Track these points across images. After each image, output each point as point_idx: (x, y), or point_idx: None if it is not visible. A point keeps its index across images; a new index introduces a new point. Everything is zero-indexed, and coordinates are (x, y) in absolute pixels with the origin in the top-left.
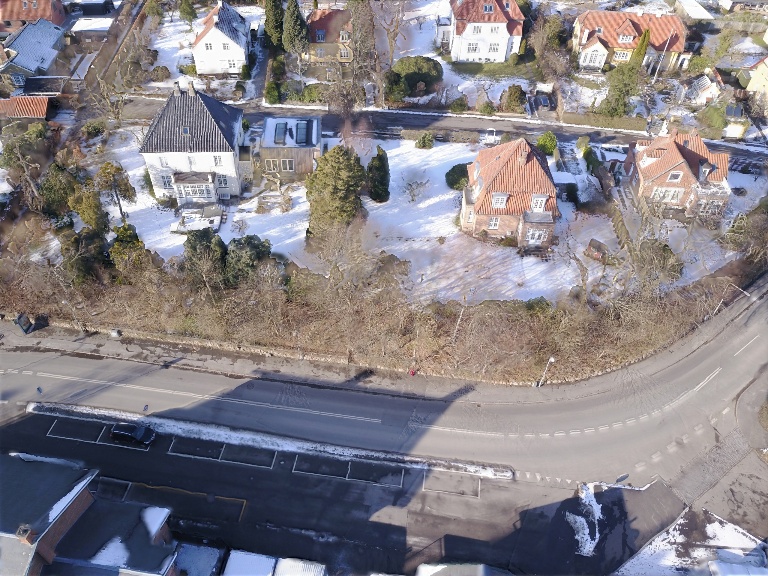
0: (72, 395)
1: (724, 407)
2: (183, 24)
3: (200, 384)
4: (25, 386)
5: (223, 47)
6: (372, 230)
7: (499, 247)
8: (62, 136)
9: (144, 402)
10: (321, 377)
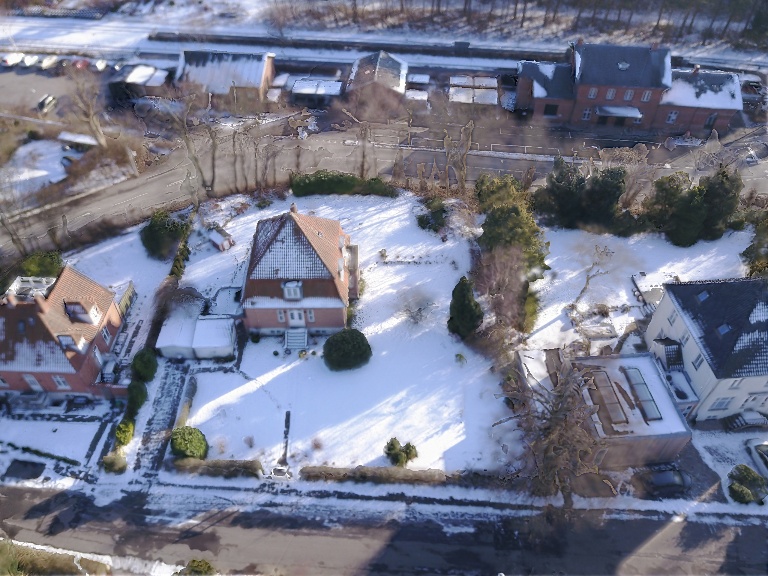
0: (647, 172)
1: (186, 166)
2: None
3: None
4: None
5: None
6: (461, 273)
7: None
8: None
9: None
10: None
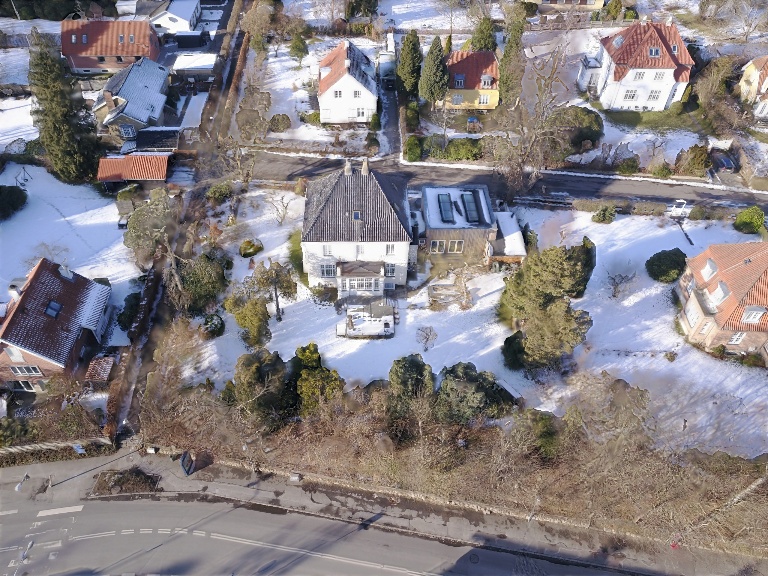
0: (259, 569)
1: None
2: (289, 59)
3: (412, 554)
4: (200, 554)
5: (354, 95)
6: None
7: (743, 367)
8: (184, 201)
9: None
10: (559, 546)
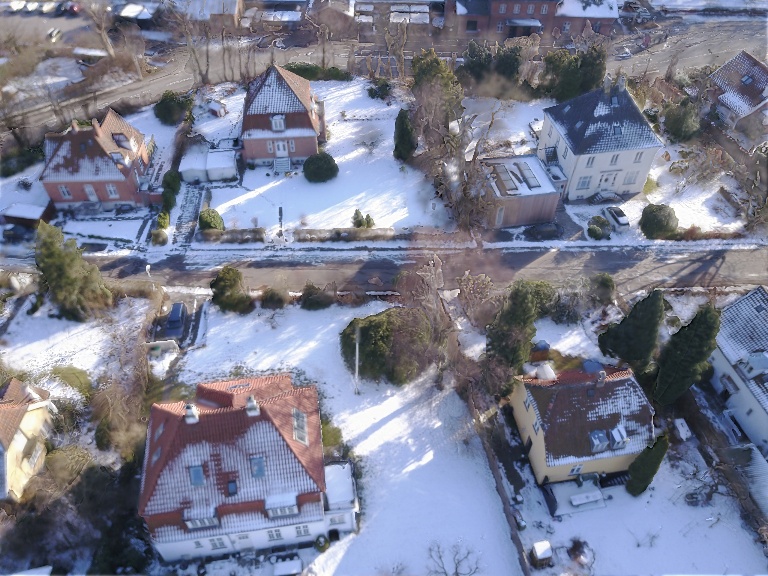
0: None
1: (180, 72)
2: None
3: None
4: None
5: None
6: None
7: None
8: None
9: None
10: None
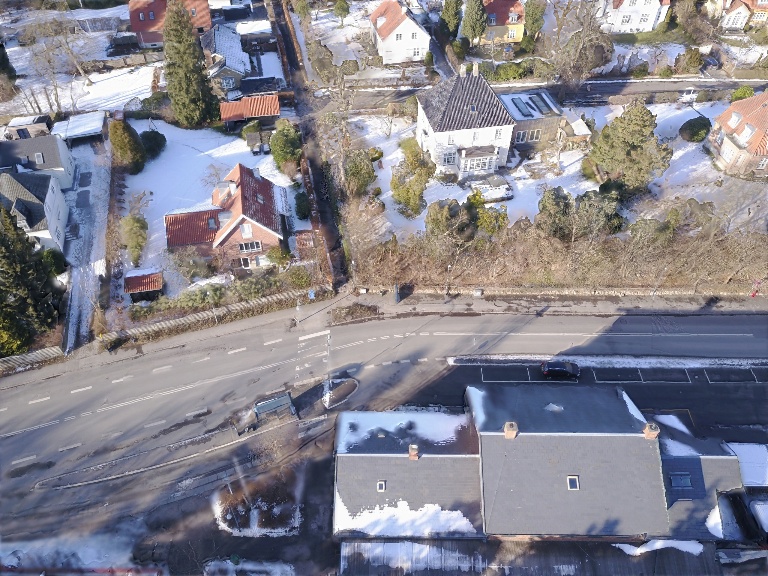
0: (479, 347)
1: None
2: (329, 21)
3: (581, 325)
4: (432, 345)
5: (411, 36)
6: None
7: None
8: None
9: (546, 345)
10: (678, 307)
